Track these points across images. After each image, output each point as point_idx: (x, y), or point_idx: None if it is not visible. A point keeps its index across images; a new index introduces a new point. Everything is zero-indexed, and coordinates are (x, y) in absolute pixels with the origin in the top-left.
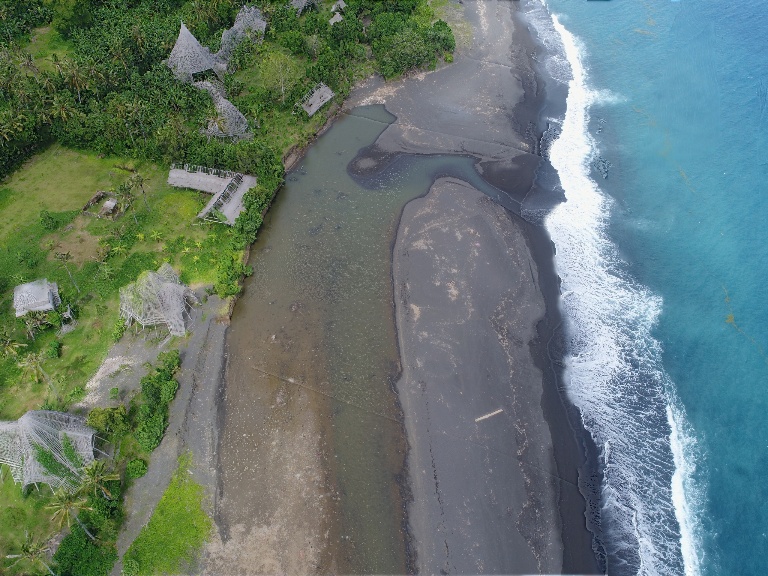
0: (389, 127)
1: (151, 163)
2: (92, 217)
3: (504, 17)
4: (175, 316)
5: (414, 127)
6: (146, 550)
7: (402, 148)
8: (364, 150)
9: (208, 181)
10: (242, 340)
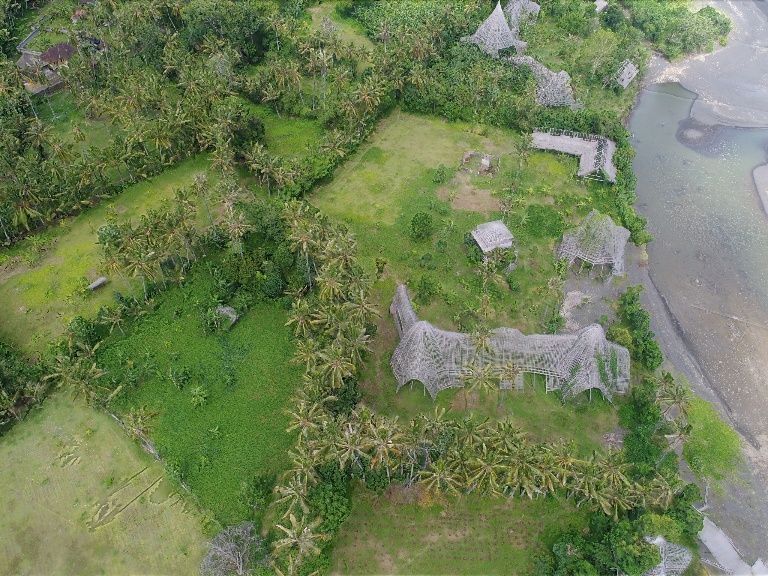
0: (696, 102)
1: (495, 128)
2: (470, 173)
3: (751, 6)
4: (619, 257)
5: (721, 103)
6: (698, 451)
7: (720, 121)
8: (684, 122)
9: (572, 144)
10: (669, 283)
